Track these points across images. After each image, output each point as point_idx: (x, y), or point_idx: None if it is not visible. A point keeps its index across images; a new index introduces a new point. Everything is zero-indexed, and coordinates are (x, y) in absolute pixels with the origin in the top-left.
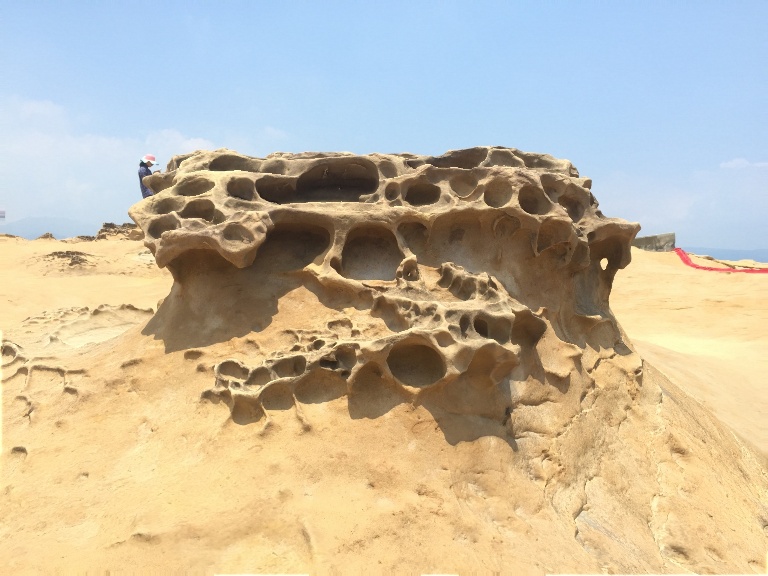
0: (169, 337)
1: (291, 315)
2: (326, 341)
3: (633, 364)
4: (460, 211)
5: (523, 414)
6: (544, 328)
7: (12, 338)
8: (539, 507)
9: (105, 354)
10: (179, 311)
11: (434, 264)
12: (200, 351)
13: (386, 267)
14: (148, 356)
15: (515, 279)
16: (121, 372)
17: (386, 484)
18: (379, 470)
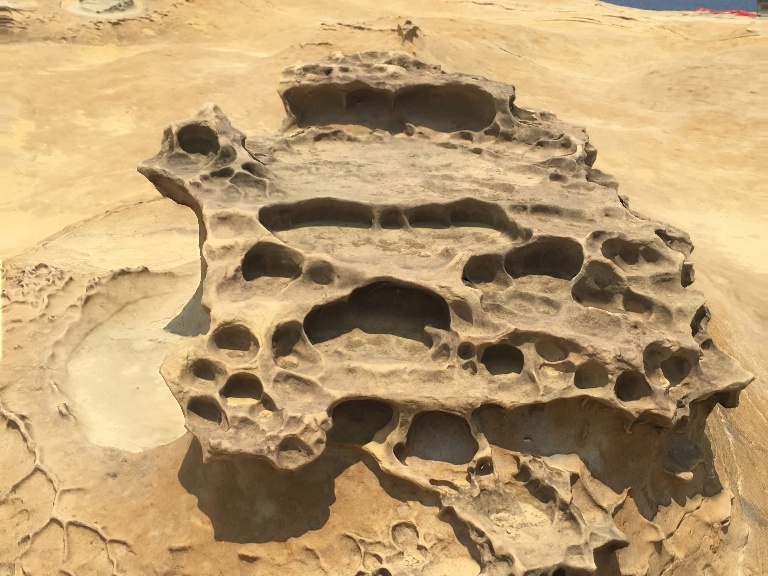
0: (217, 518)
1: (350, 505)
2: (393, 575)
3: (721, 512)
4: (545, 402)
5: None
6: (626, 546)
7: (3, 369)
8: None
9: (143, 506)
10: (224, 482)
11: (510, 445)
12: (256, 557)
13: (455, 442)
14: (197, 542)
15: (600, 453)
16: (170, 558)
17: None
18: None
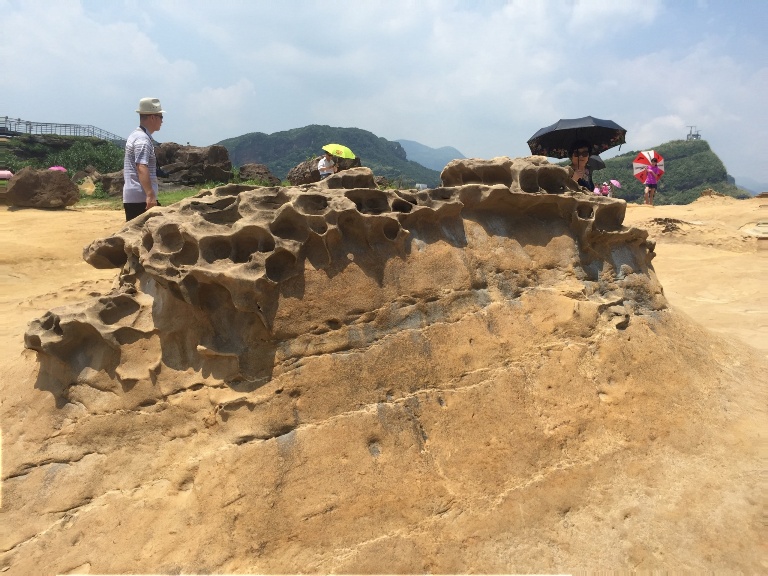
0: None
1: None
2: None
3: None
4: None
5: (80, 390)
6: None
7: None
8: (31, 440)
9: None
10: None
11: None
12: None
13: None
14: None
15: None
16: None
17: (1, 391)
18: (7, 384)
